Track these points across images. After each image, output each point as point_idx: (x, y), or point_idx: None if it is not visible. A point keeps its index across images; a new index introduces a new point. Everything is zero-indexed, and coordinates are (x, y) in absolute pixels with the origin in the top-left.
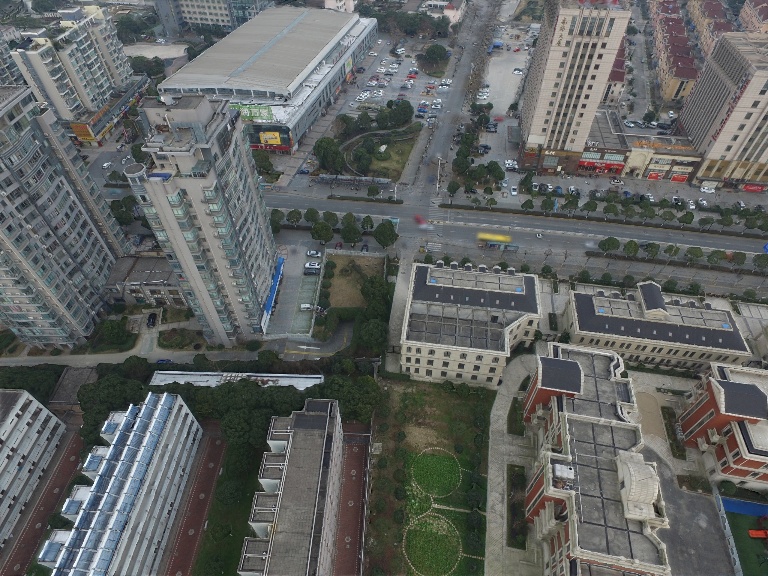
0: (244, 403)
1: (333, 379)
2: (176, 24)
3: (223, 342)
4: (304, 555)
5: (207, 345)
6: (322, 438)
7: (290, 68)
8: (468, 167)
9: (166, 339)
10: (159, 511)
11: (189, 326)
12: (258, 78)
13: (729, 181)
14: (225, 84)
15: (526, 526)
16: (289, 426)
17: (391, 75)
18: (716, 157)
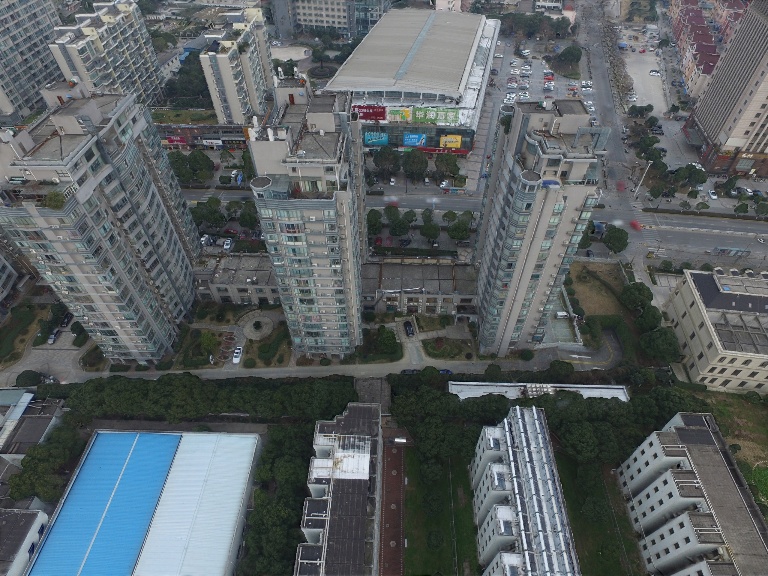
0: (580, 416)
1: (667, 391)
2: (291, 26)
3: (499, 351)
4: None
5: (479, 354)
6: (719, 454)
7: (450, 70)
8: (665, 170)
9: (435, 348)
10: None
11: (449, 335)
12: (424, 81)
13: None
14: (395, 87)
15: None
16: (678, 441)
17: (527, 77)
18: None
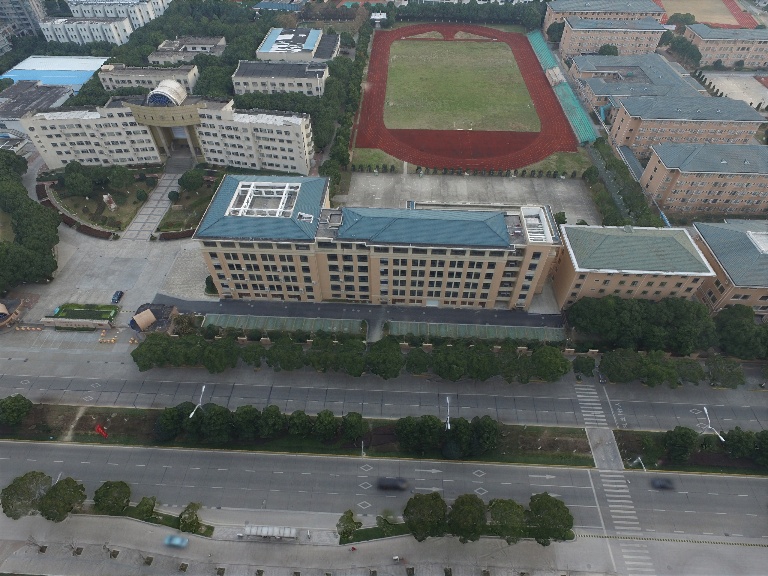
0: None
1: None
2: None
3: None
4: None
5: None
6: None
7: None
8: None
9: None
10: None
11: None
12: None
13: None
14: None
15: None
16: None
17: None
18: None
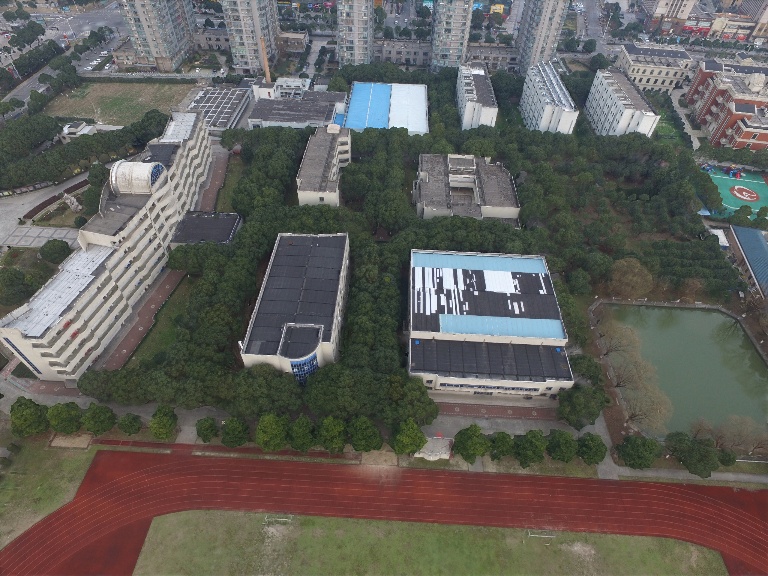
0: None
1: None
2: None
3: None
4: None
5: None
6: None
7: None
8: None
9: None
10: None
11: None
12: None
13: None
14: None
15: (700, 124)
16: (607, 71)
17: None
18: (765, 22)
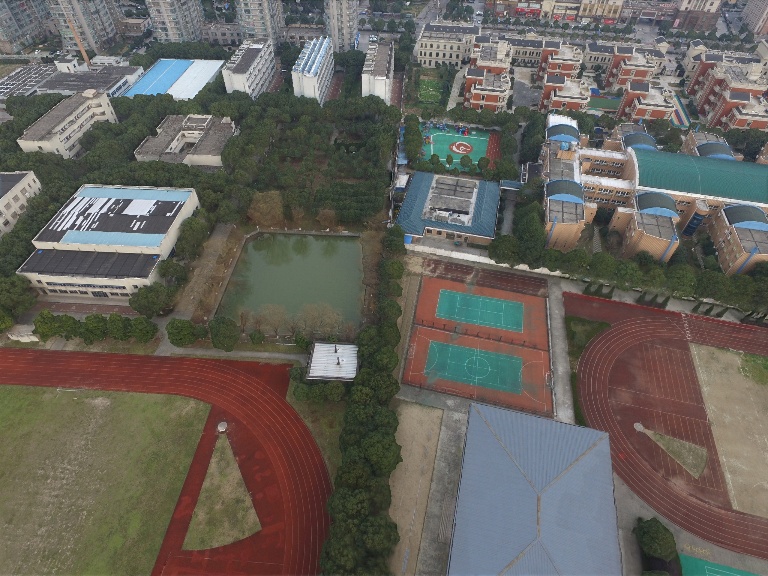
0: None
1: None
2: None
3: None
4: (386, 61)
5: None
6: None
7: None
8: None
9: None
10: (326, 75)
11: None
12: None
13: (595, 17)
14: None
15: None
16: (376, 44)
17: None
18: (587, 2)
